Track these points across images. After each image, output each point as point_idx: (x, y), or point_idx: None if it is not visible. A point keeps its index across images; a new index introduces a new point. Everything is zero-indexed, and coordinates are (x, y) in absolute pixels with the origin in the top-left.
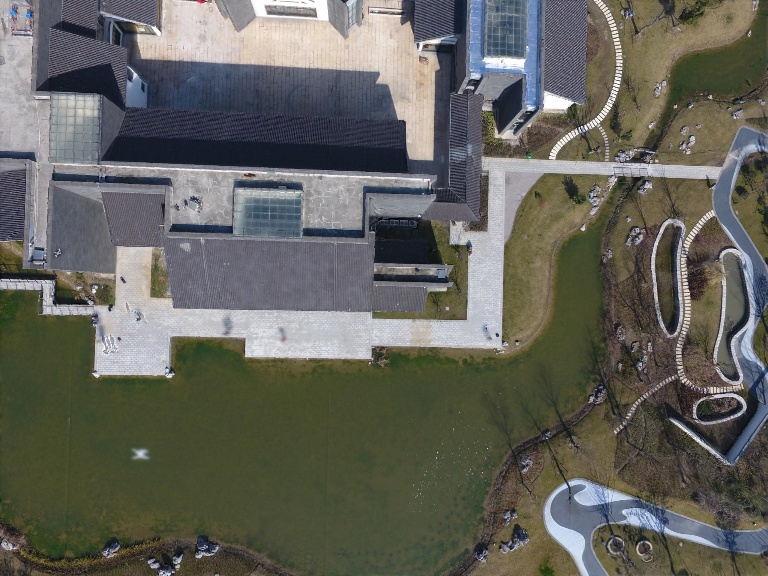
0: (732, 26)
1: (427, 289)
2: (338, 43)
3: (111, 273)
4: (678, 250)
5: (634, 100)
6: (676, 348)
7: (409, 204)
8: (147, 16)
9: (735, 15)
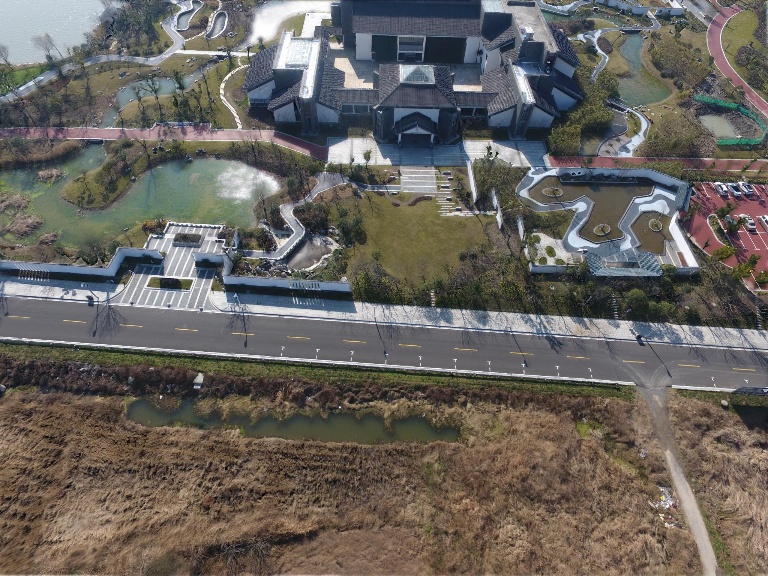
0: None
1: None
2: None
3: None
4: (210, 31)
5: None
6: (221, 8)
7: None
8: None
9: None
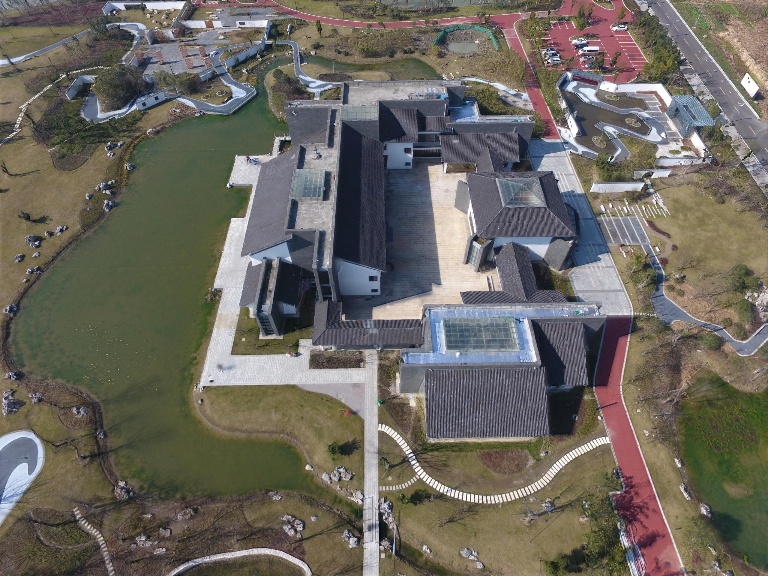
0: None
1: None
2: (459, 259)
3: None
4: None
5: (451, 519)
6: None
7: None
8: (446, 158)
9: None
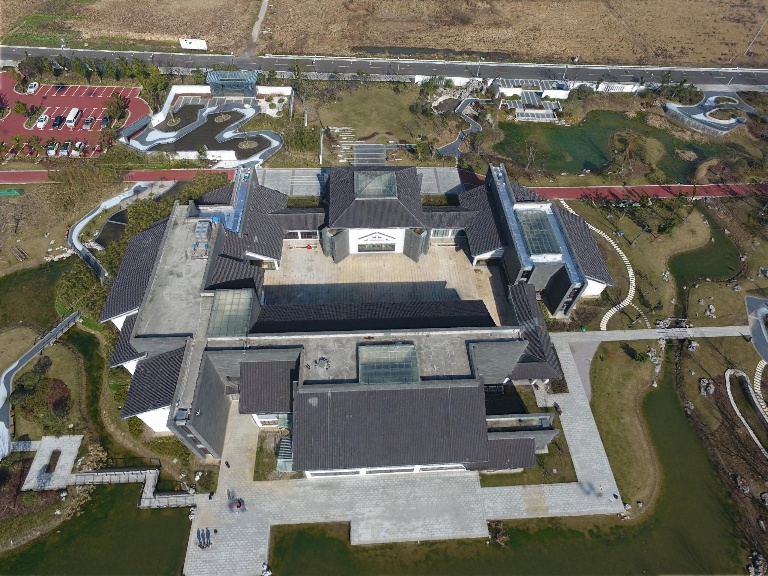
0: (697, 236)
1: (534, 440)
2: (411, 265)
3: (218, 457)
4: (752, 396)
5: (650, 284)
6: None
7: (503, 356)
8: (275, 254)
9: (696, 230)
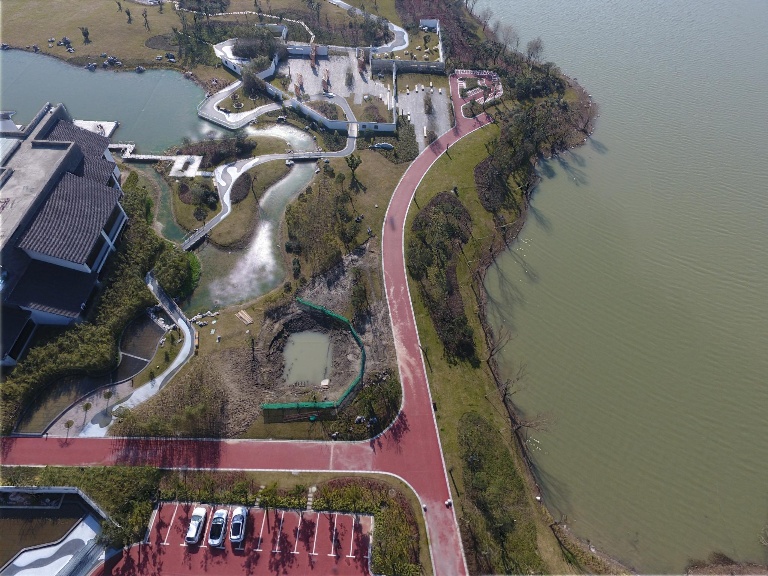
0: None
1: None
2: None
3: None
4: None
5: None
6: None
7: None
8: None
9: None
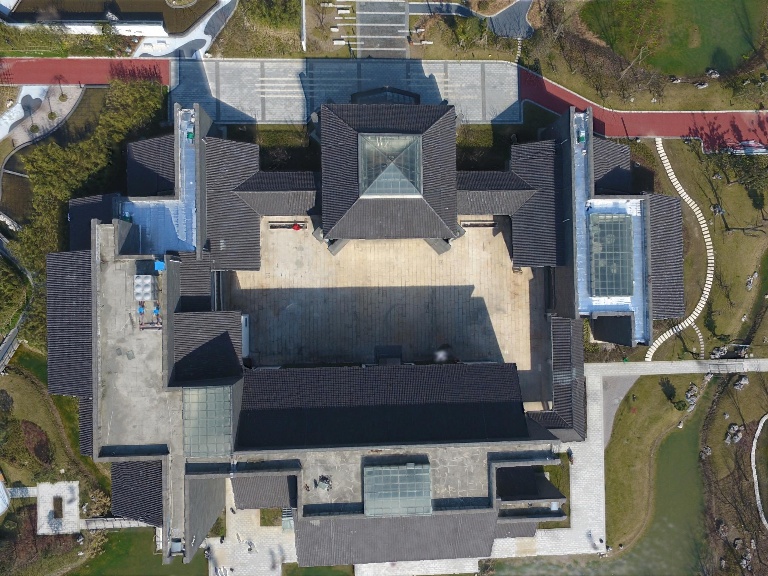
0: None
1: None
2: (432, 259)
3: None
4: None
5: (727, 296)
6: None
7: None
8: (252, 262)
9: None
